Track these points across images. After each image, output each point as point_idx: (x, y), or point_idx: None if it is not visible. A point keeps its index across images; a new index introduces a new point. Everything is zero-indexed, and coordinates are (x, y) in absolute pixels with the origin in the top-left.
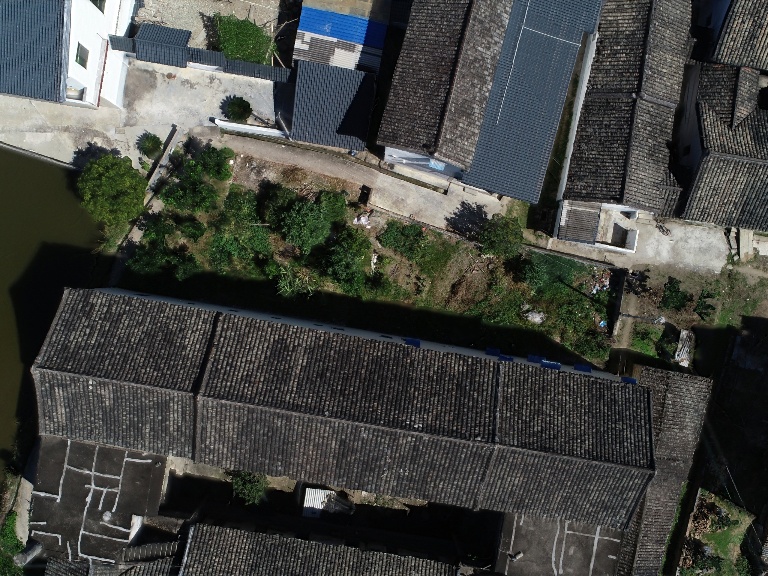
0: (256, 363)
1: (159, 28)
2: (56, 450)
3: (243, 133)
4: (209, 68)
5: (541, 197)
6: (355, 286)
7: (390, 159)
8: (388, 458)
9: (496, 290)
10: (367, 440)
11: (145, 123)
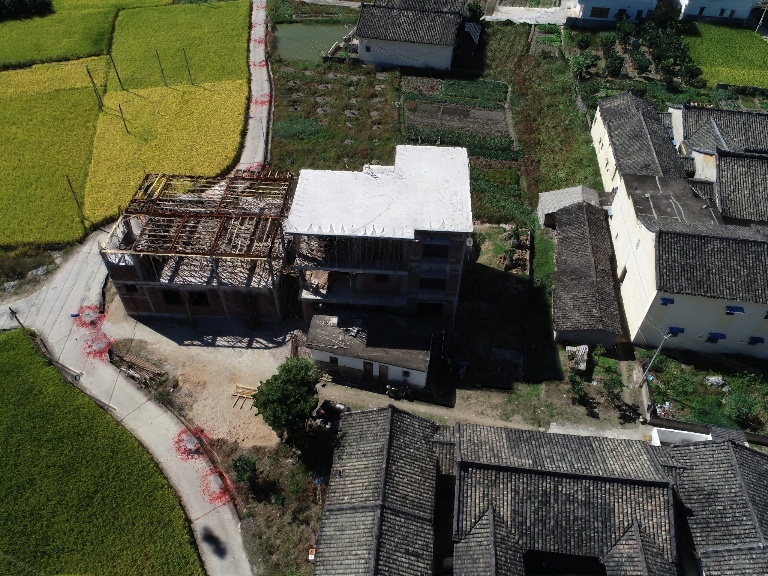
0: None
1: None
2: None
3: None
4: None
5: None
6: None
7: None
8: None
9: (760, 401)
10: None
11: None
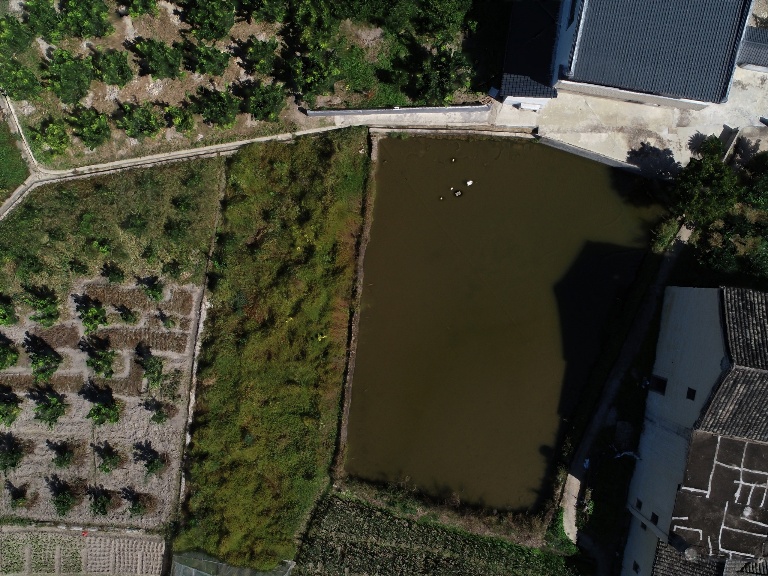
0: None
1: (759, 30)
2: (706, 446)
3: None
4: (767, 69)
5: None
6: None
7: None
8: None
9: None
10: None
11: (697, 124)
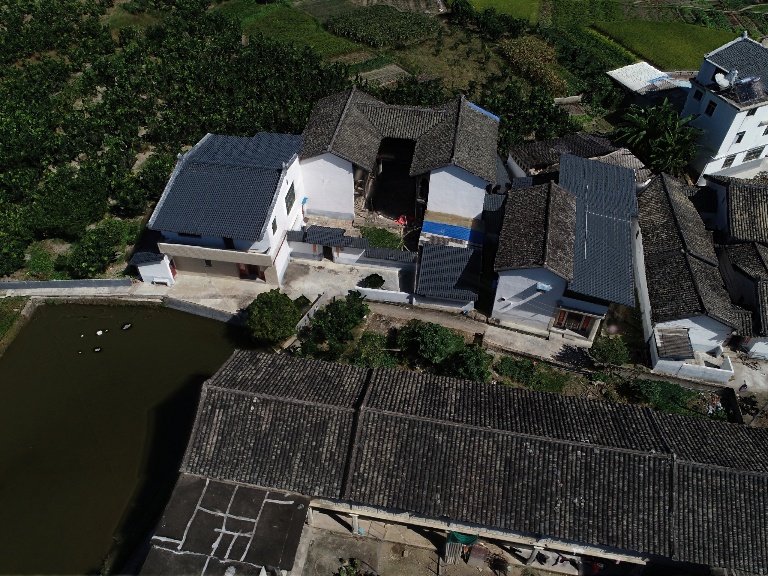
0: (412, 394)
1: (324, 227)
2: (191, 490)
3: (374, 301)
4: (351, 261)
5: (631, 341)
6: (486, 381)
7: (498, 310)
8: (559, 482)
9: None
10: (534, 458)
11: (297, 294)
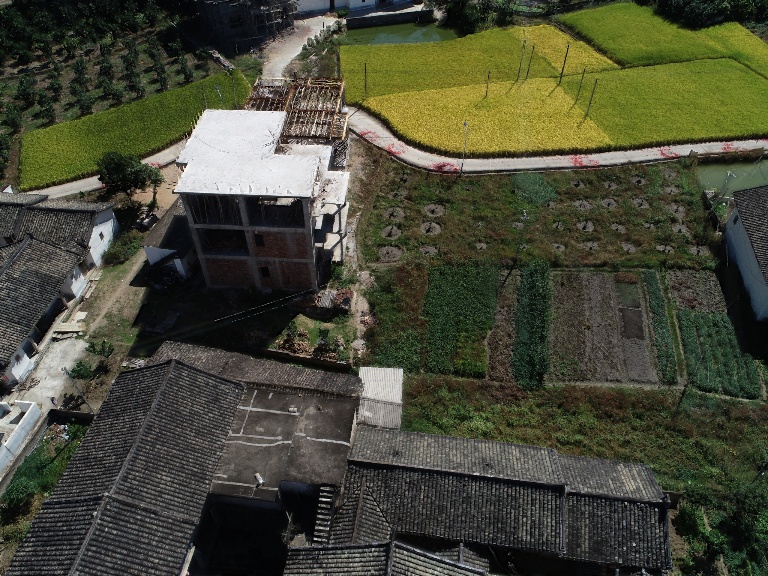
0: None
1: None
2: None
3: None
4: None
5: None
6: None
7: None
8: None
9: None
10: None
11: None
